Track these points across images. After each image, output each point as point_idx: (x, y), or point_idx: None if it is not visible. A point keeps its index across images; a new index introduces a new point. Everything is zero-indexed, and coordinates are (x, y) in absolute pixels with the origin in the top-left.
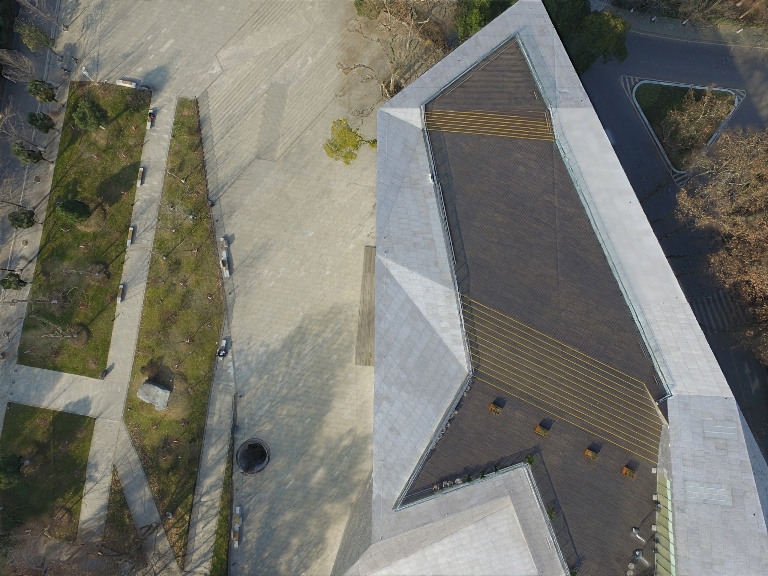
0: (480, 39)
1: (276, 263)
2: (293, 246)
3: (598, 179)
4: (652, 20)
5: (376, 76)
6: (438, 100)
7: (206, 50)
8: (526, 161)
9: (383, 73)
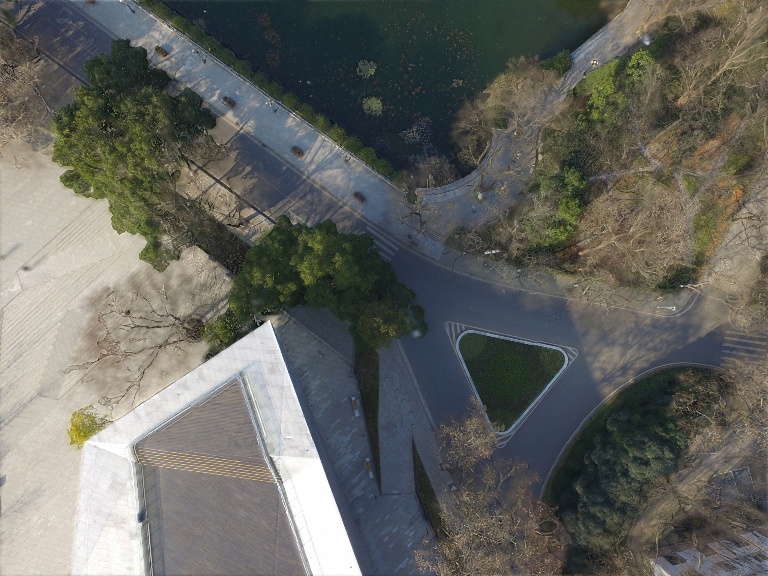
0: (204, 372)
1: (47, 510)
2: (67, 493)
3: (322, 534)
4: (485, 265)
5: (176, 314)
6: (151, 437)
7: (7, 266)
8: (248, 504)
9: (184, 311)
